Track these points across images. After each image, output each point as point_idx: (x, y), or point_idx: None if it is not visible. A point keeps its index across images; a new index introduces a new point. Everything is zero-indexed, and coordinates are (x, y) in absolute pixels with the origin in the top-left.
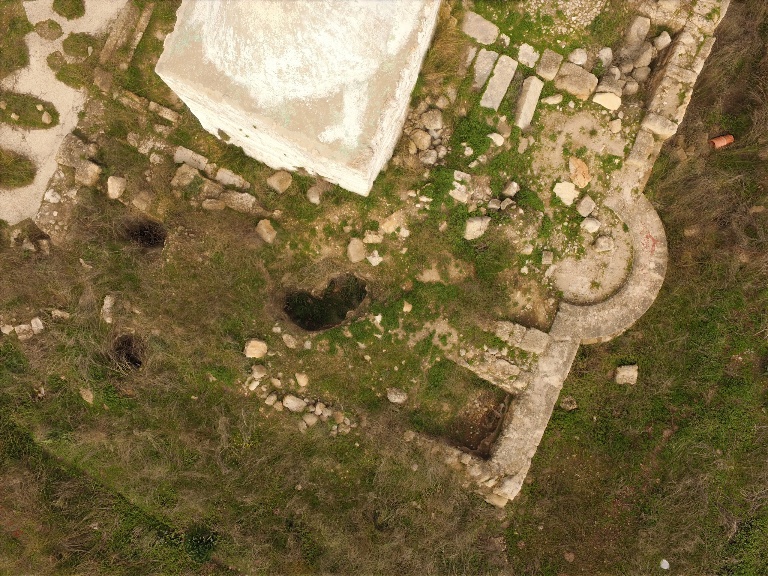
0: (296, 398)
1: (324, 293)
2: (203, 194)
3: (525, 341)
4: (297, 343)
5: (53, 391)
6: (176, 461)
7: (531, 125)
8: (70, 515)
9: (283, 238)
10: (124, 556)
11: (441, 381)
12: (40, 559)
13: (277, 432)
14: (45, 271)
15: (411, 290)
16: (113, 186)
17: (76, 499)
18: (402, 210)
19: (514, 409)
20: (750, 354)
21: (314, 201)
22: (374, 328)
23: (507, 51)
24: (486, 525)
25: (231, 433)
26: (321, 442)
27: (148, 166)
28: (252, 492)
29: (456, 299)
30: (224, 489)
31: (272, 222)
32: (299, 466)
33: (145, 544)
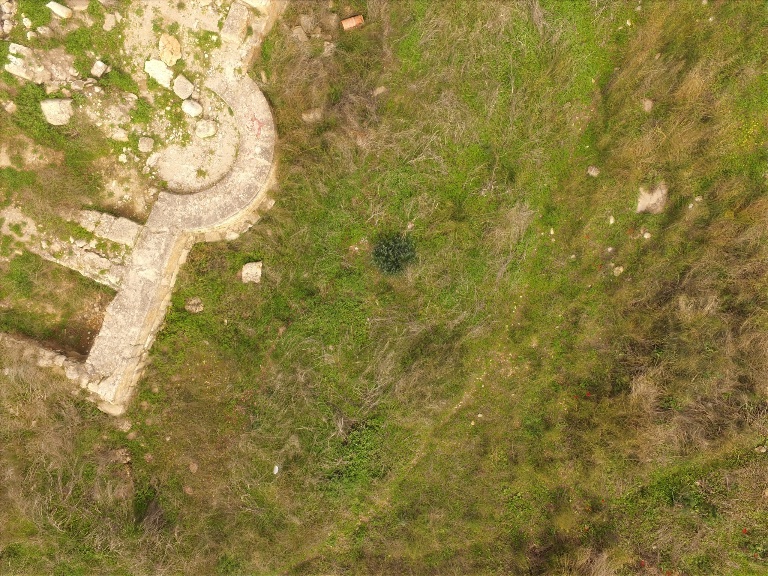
0: None
1: None
2: None
3: (112, 231)
4: None
5: None
6: None
7: None
8: None
9: None
10: None
11: (27, 277)
12: None
13: None
14: None
15: None
16: None
17: None
18: None
19: (108, 306)
20: (365, 243)
21: None
22: None
23: None
24: (106, 436)
25: None
26: None
27: None
28: None
29: (31, 186)
30: None
31: None
32: None
33: None
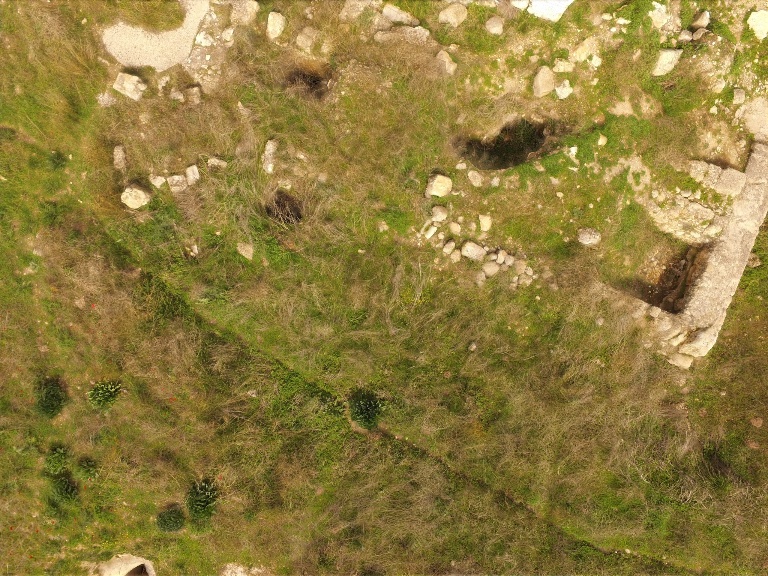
0: (476, 245)
1: (496, 140)
2: (374, 27)
3: (721, 181)
4: (484, 180)
5: (208, 247)
6: (340, 322)
7: None
8: (229, 379)
9: (464, 70)
10: (285, 425)
11: (629, 227)
12: (197, 427)
13: (450, 287)
14: (204, 113)
15: (603, 124)
16: (274, 22)
17: (234, 363)
18: (595, 36)
19: (707, 257)
20: None
21: (496, 31)
22: (569, 161)
23: None
24: (667, 390)
25: (402, 288)
26: (503, 293)
27: (308, 3)
28: (427, 350)
29: (649, 135)
30: (391, 351)
31: (451, 54)
32: (484, 315)
33: (311, 408)
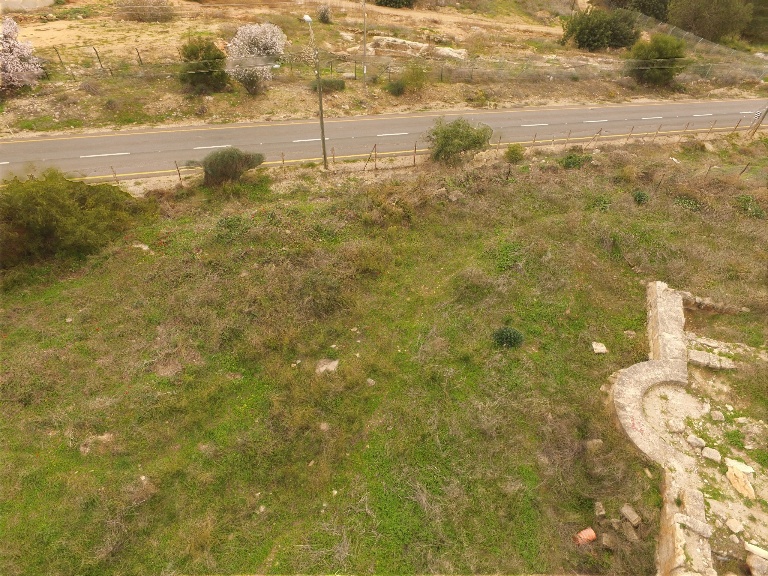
0: None
1: None
2: None
3: (707, 356)
4: None
5: None
6: None
7: None
8: None
9: None
10: None
11: None
12: None
13: None
14: None
15: None
16: None
17: None
18: None
19: None
20: None
21: None
22: None
23: None
24: None
25: None
26: None
27: None
28: None
29: None
30: None
31: None
32: None
33: None
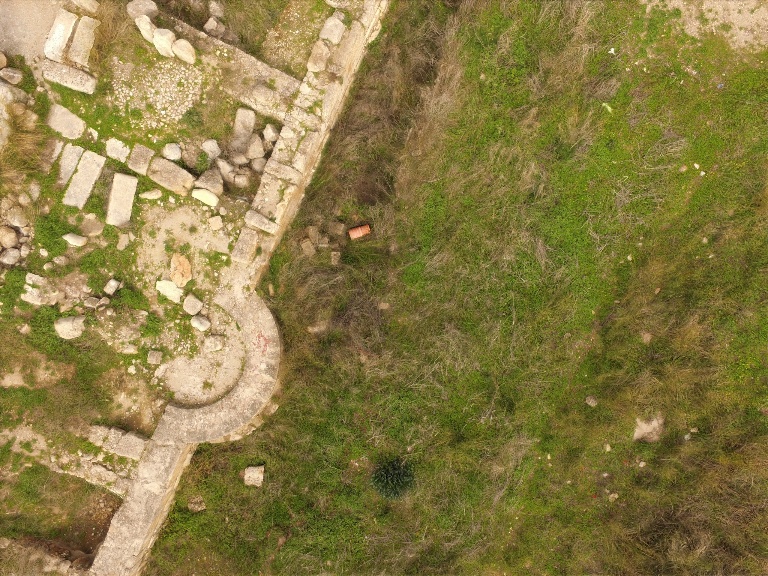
0: None
1: None
2: None
3: (119, 447)
4: None
5: None
6: None
7: (130, 221)
8: None
9: None
10: None
11: (36, 487)
12: None
13: None
14: None
15: None
16: None
17: None
18: None
19: (113, 517)
20: (365, 460)
21: None
22: None
23: (93, 146)
24: None
25: None
26: None
27: None
28: None
29: (43, 404)
30: None
31: None
32: None
33: None
